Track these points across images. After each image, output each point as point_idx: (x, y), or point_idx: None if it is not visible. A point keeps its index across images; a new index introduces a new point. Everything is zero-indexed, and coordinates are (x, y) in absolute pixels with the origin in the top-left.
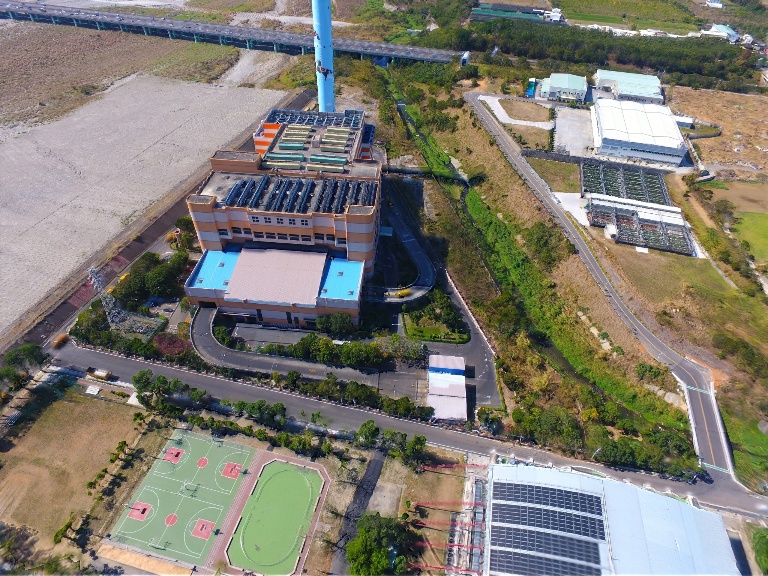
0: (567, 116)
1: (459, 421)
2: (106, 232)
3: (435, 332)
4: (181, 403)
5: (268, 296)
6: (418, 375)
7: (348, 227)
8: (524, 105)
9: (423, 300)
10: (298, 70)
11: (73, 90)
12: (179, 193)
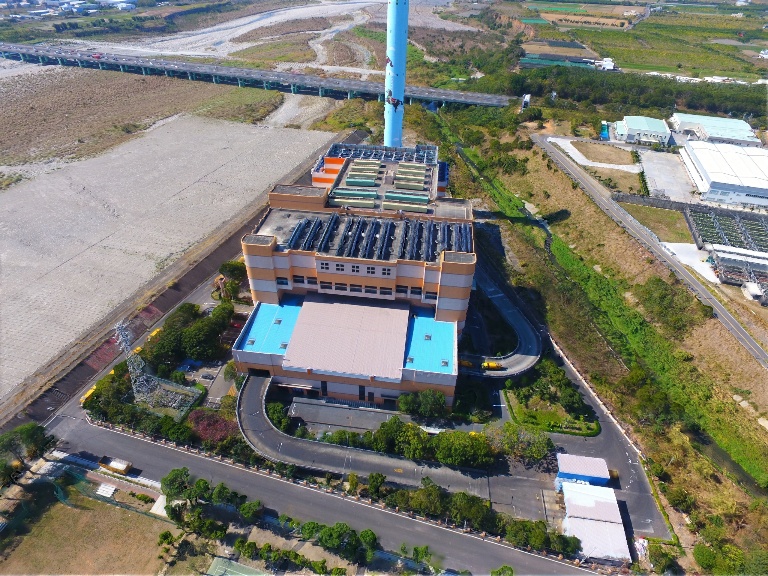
0: (653, 159)
1: (620, 562)
2: (138, 277)
3: (552, 418)
4: (223, 515)
5: (339, 365)
6: (542, 482)
7: (442, 278)
8: (601, 147)
9: (529, 373)
10: (345, 113)
11: (114, 128)
12: (223, 234)
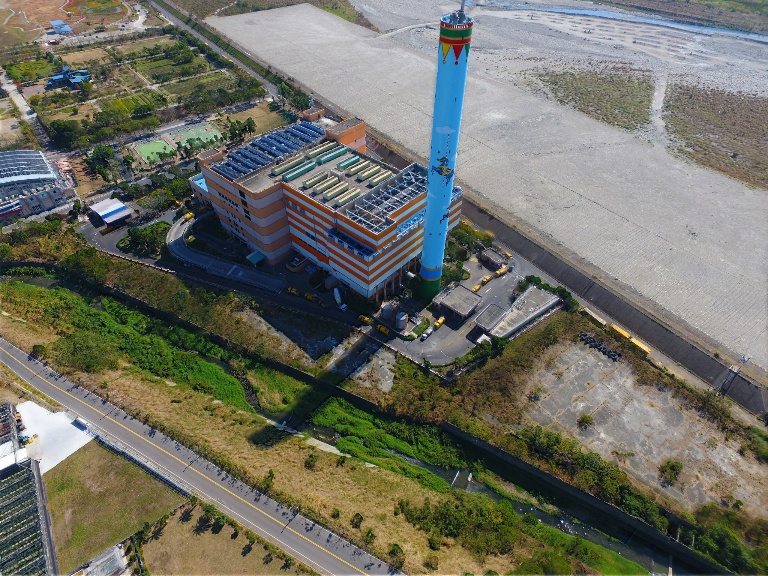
0: None
1: None
2: (425, 151)
3: None
4: None
5: None
6: None
7: None
8: None
9: None
10: None
11: None
12: None
